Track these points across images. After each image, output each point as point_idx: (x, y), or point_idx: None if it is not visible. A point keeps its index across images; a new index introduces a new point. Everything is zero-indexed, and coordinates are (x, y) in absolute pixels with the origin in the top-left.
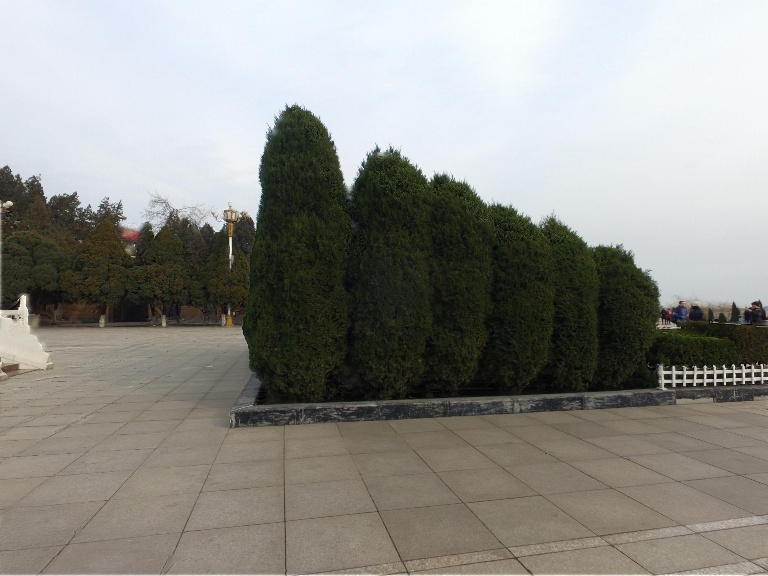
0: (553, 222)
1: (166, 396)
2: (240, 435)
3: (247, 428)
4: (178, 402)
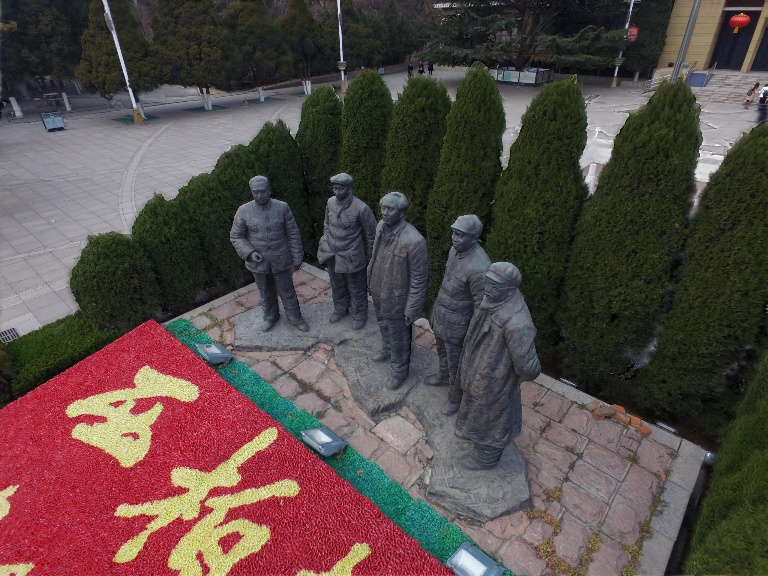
0: (157, 197)
1: None
2: None
3: None
4: None
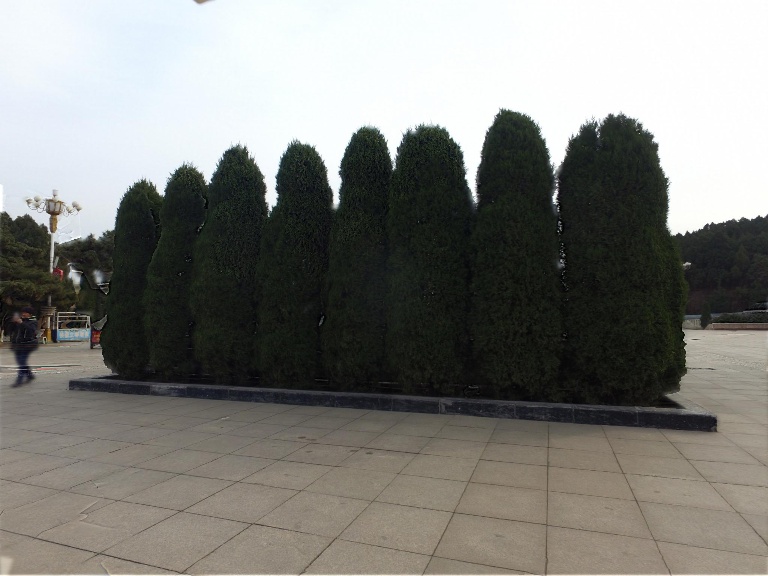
0: None
1: (512, 442)
2: (748, 431)
3: (717, 428)
4: (562, 440)
